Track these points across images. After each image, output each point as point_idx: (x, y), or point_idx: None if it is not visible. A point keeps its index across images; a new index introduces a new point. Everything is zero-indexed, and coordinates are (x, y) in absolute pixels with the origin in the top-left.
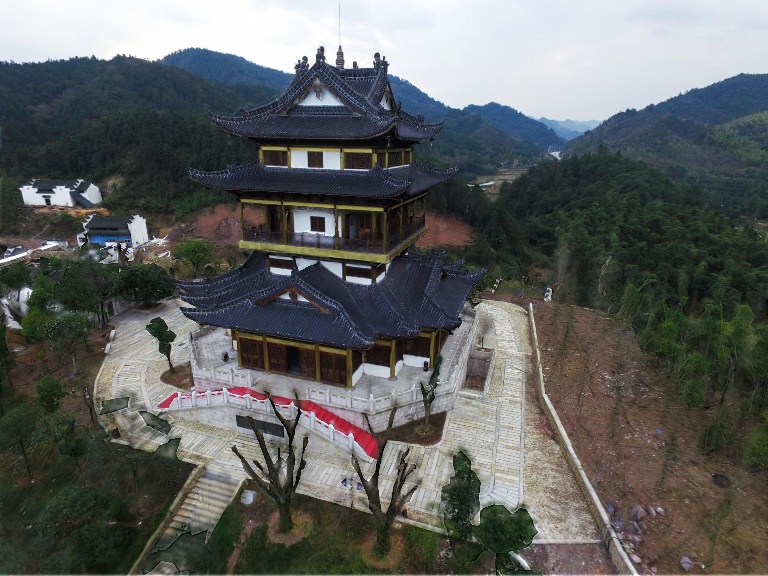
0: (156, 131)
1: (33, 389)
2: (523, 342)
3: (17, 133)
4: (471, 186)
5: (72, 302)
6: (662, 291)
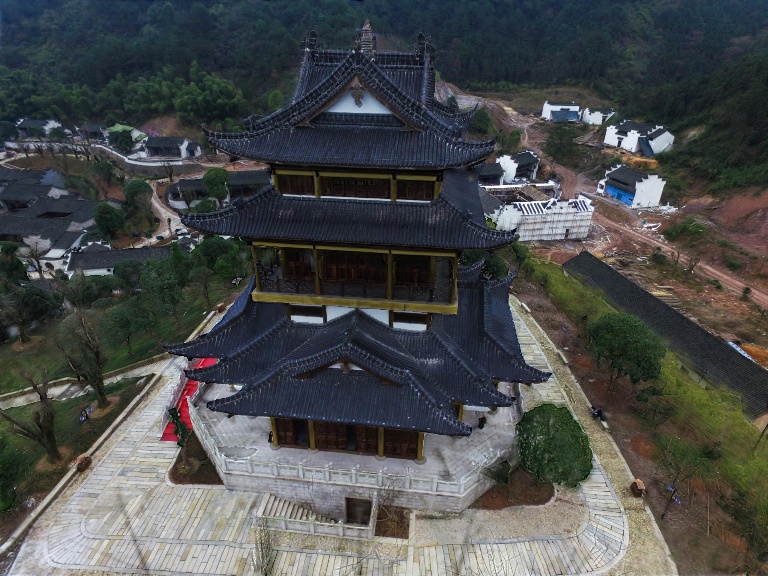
0: None
1: None
2: None
3: (691, 69)
4: None
5: None
6: None
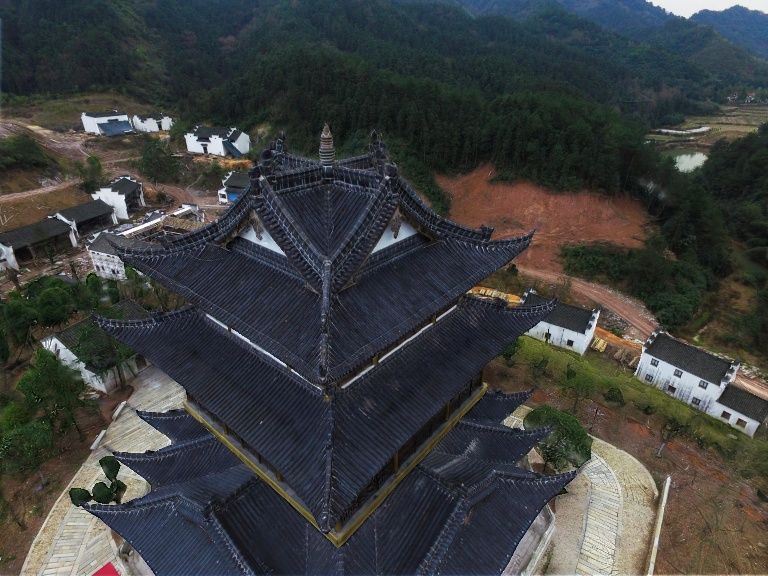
0: (304, 76)
1: (11, 488)
2: None
3: (205, 68)
4: (674, 133)
5: (51, 398)
6: None
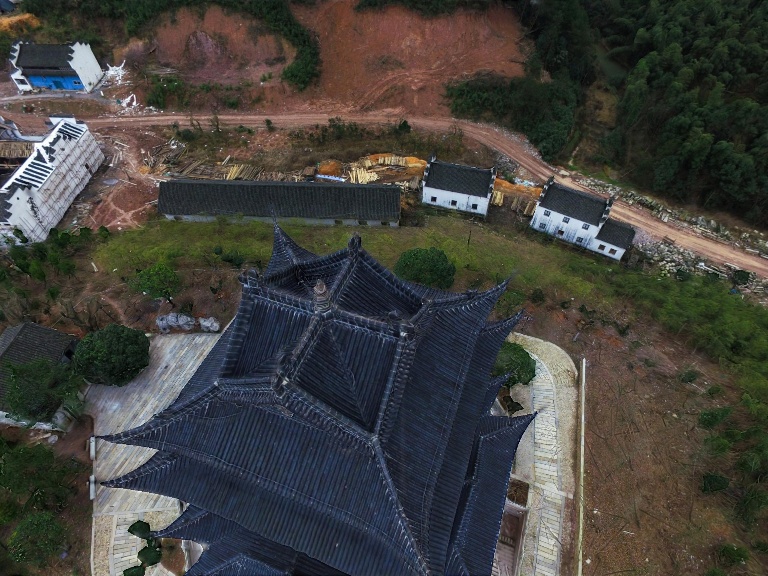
0: None
1: None
2: (565, 464)
3: None
4: None
5: None
6: (752, 182)
